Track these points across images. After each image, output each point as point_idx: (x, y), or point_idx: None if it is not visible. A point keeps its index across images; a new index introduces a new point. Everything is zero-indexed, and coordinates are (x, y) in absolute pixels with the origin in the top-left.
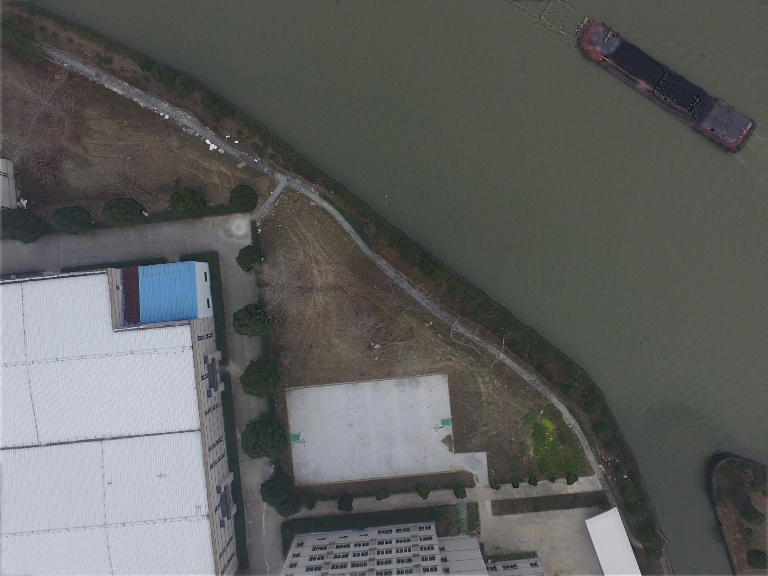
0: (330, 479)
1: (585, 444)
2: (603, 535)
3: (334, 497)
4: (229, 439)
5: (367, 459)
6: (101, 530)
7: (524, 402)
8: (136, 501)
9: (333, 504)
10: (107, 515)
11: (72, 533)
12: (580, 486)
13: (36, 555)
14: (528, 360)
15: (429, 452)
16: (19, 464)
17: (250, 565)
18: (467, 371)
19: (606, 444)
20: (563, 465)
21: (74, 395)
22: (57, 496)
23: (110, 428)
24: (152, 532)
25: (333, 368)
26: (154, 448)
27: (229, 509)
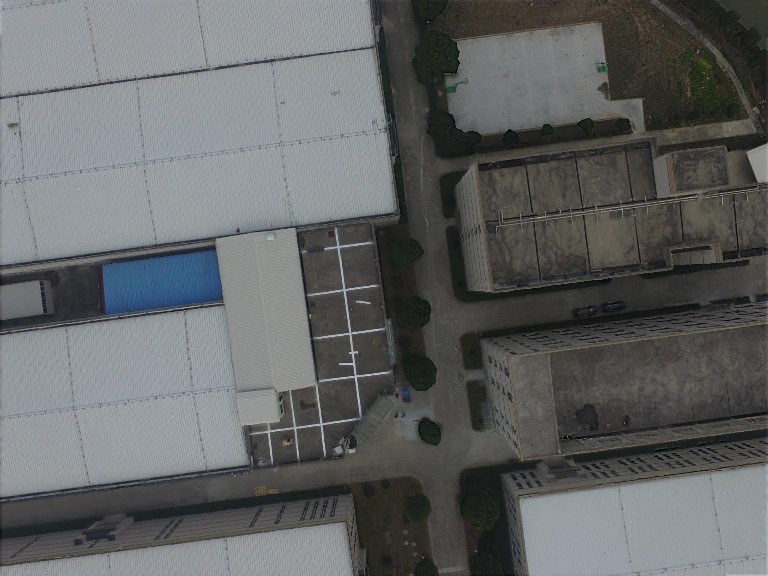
0: (487, 131)
1: (739, 87)
2: (764, 166)
3: (492, 147)
4: (385, 92)
5: (524, 109)
6: (276, 149)
7: (681, 41)
8: (311, 119)
9: (491, 156)
10: (282, 134)
11: (246, 153)
12: (735, 130)
13: (209, 179)
14: (683, 0)
15: (585, 100)
16: (188, 89)
17: (409, 221)
18: (622, 14)
19: (764, 77)
20: (719, 107)
21: (243, 14)
22: (229, 118)
23: (281, 48)
24: (328, 149)
25: (488, 16)
26: (326, 67)
27: (396, 143)
